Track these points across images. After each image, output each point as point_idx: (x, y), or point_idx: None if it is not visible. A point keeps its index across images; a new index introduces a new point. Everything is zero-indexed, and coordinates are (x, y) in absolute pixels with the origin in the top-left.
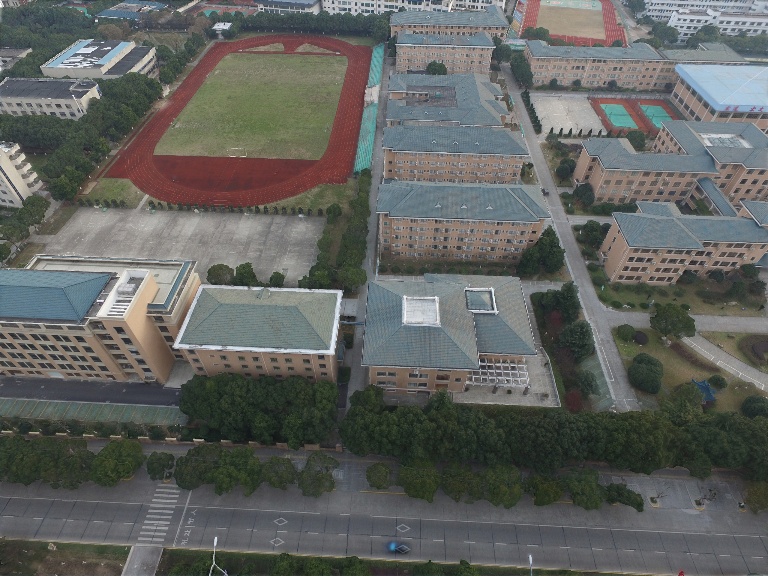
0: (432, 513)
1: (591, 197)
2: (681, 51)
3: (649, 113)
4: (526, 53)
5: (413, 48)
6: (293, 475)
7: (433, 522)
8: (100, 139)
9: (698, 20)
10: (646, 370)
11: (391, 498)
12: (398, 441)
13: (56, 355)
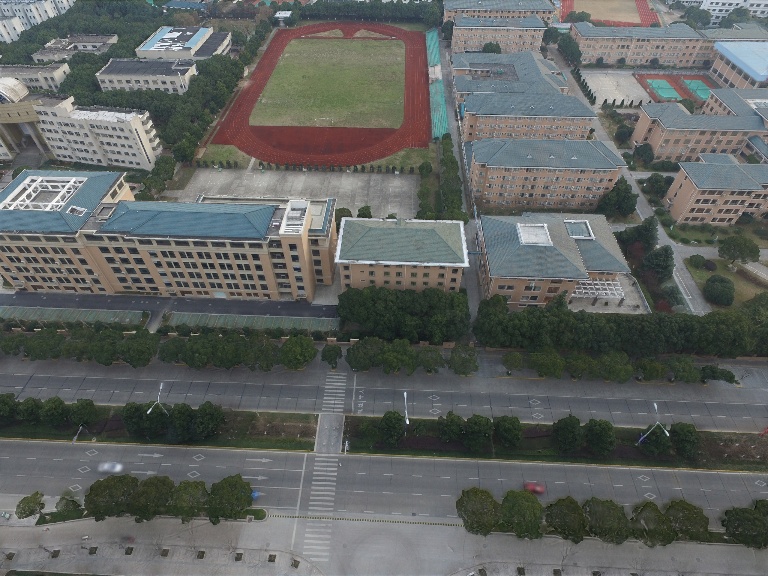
0: (556, 392)
1: (651, 155)
2: (719, 30)
3: (692, 86)
4: (573, 34)
5: (470, 30)
6: (443, 360)
7: (558, 398)
8: (205, 110)
9: (730, 3)
10: (720, 287)
11: (520, 382)
12: (528, 333)
13: (228, 274)
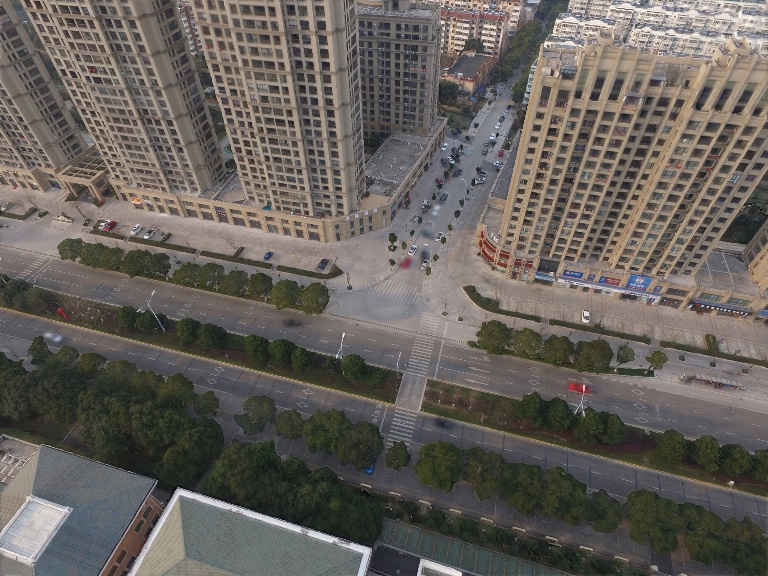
0: None
1: None
2: None
3: None
4: None
5: None
6: None
7: None
8: None
9: None
10: None
11: None
12: None
13: None
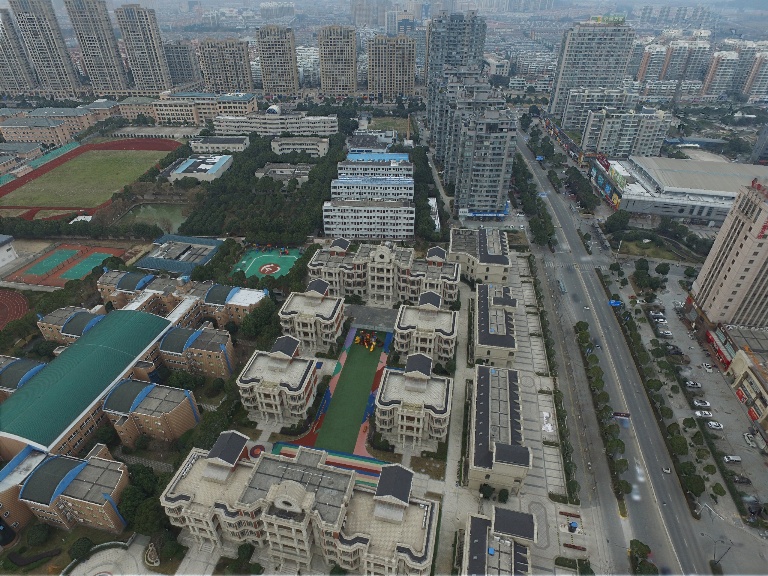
0: None
1: None
2: None
3: None
4: None
5: None
6: None
7: None
8: None
9: None
10: None
11: None
12: None
13: None
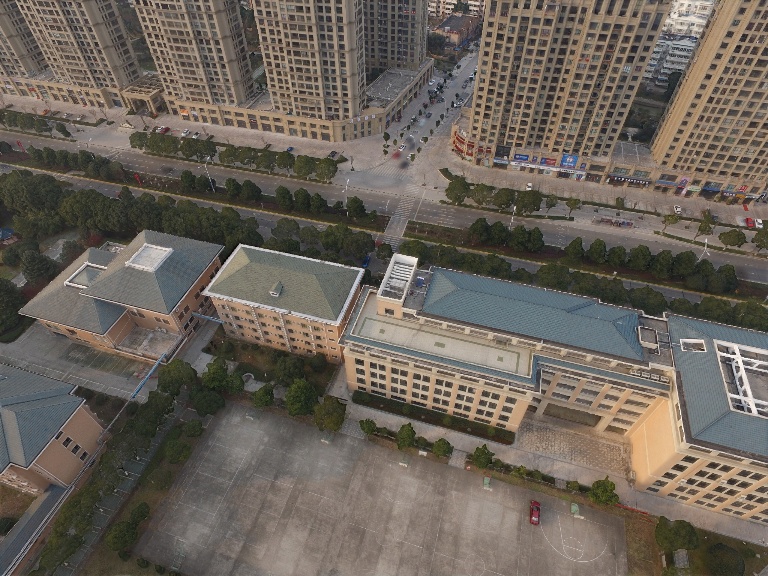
0: None
1: None
2: None
3: None
4: None
5: None
6: None
7: None
8: None
9: None
10: None
11: None
12: None
13: None
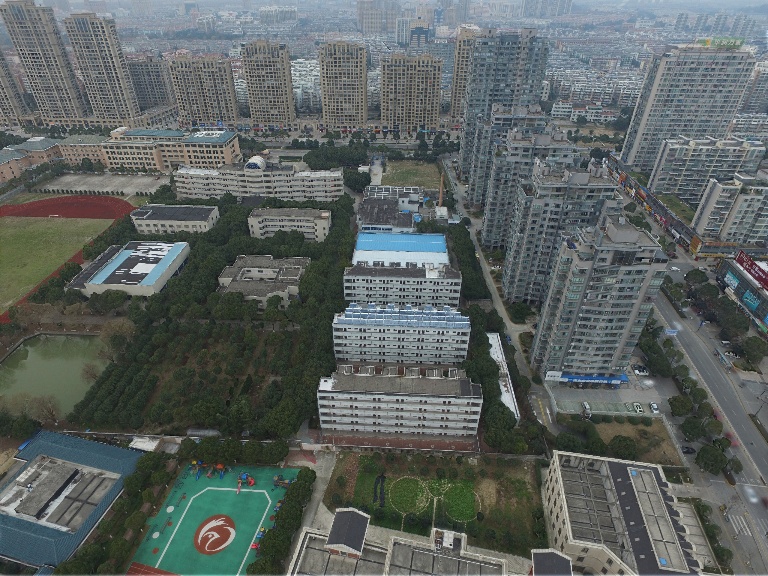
0: None
1: None
2: None
3: None
4: None
5: None
6: None
7: None
8: None
9: None
10: None
11: None
12: None
13: None
